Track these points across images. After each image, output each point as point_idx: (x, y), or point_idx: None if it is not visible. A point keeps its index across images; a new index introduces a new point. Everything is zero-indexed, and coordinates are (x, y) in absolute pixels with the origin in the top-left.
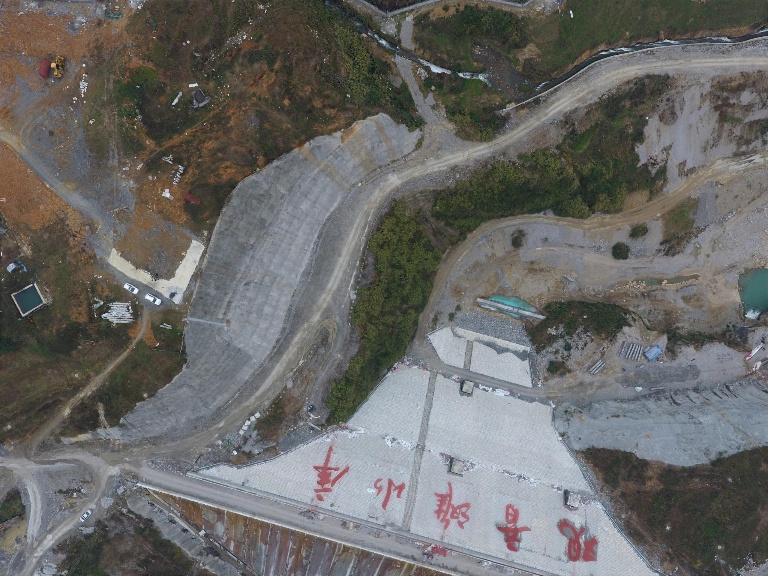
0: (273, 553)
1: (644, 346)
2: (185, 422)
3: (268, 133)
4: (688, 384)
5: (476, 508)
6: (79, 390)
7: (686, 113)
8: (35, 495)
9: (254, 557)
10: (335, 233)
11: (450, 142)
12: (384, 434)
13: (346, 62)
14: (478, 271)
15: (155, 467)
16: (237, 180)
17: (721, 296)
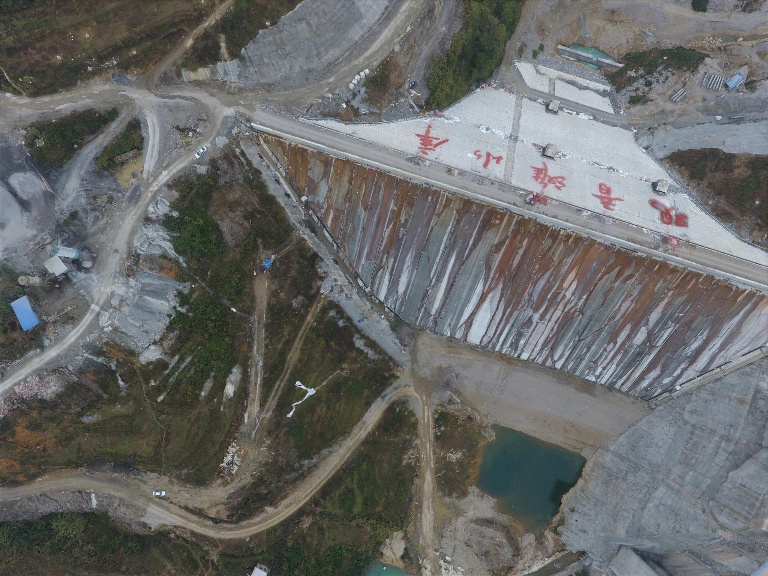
0: (371, 223)
1: (725, 77)
2: (298, 72)
3: None
4: (767, 114)
5: (571, 180)
6: (203, 20)
7: None
8: (154, 127)
9: (350, 234)
10: None
11: None
12: (479, 124)
13: None
14: (562, 13)
15: (269, 110)
16: None
17: None
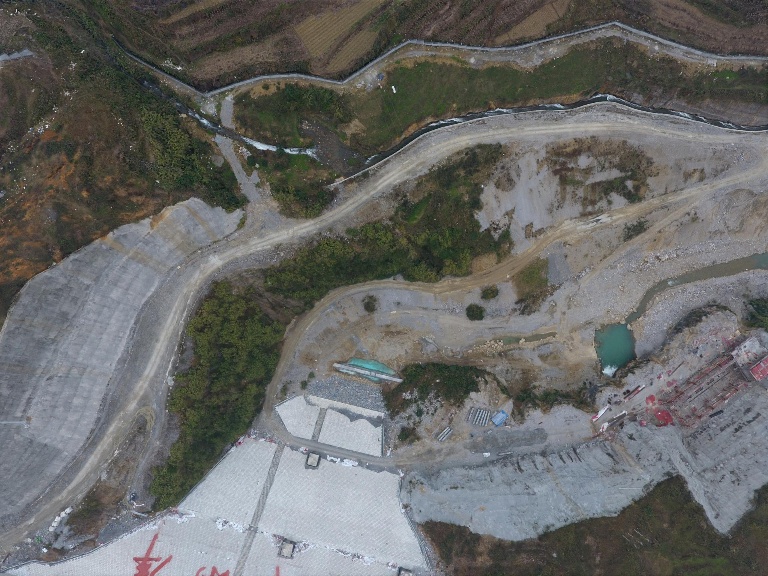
0: None
1: (492, 411)
2: None
3: (65, 226)
4: (536, 448)
5: None
6: None
7: (524, 179)
8: None
9: None
10: (152, 318)
11: (274, 220)
12: (216, 517)
13: (154, 148)
14: (331, 337)
15: None
16: (26, 278)
17: (578, 353)
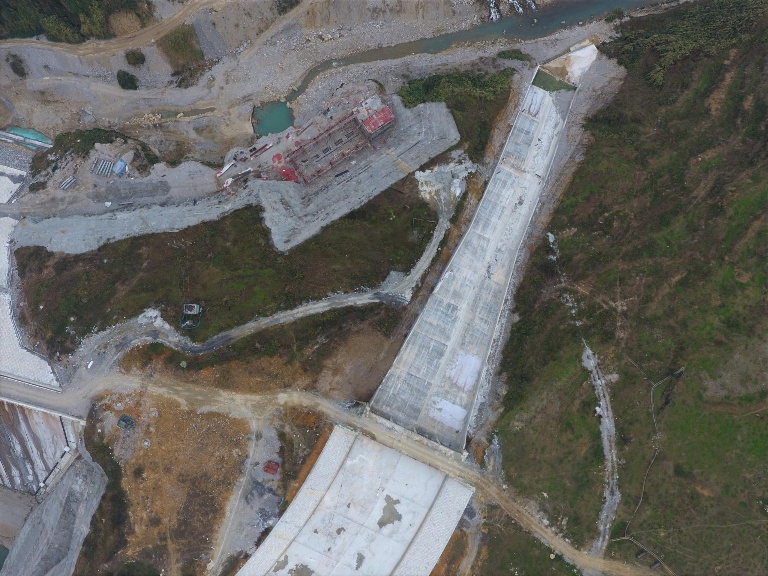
0: None
1: None
2: None
3: None
4: (157, 199)
5: None
6: None
7: None
8: None
9: None
10: None
11: None
12: None
13: None
14: None
15: None
16: None
17: (234, 128)
